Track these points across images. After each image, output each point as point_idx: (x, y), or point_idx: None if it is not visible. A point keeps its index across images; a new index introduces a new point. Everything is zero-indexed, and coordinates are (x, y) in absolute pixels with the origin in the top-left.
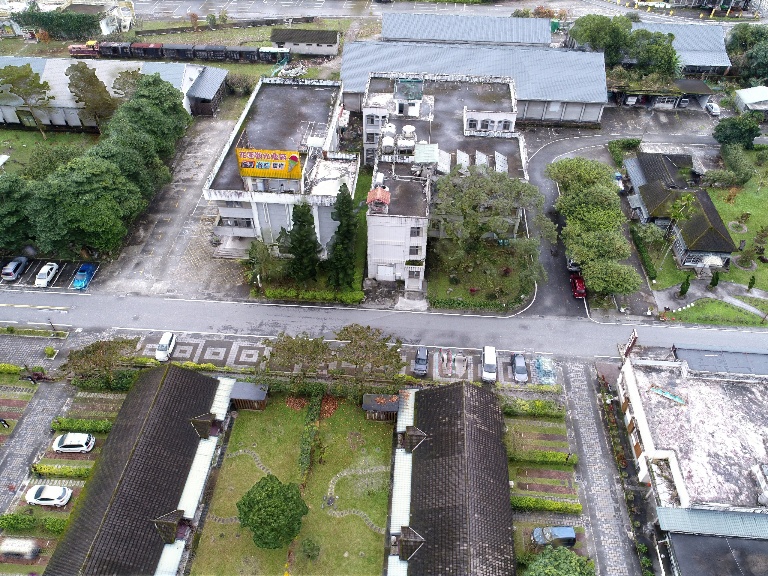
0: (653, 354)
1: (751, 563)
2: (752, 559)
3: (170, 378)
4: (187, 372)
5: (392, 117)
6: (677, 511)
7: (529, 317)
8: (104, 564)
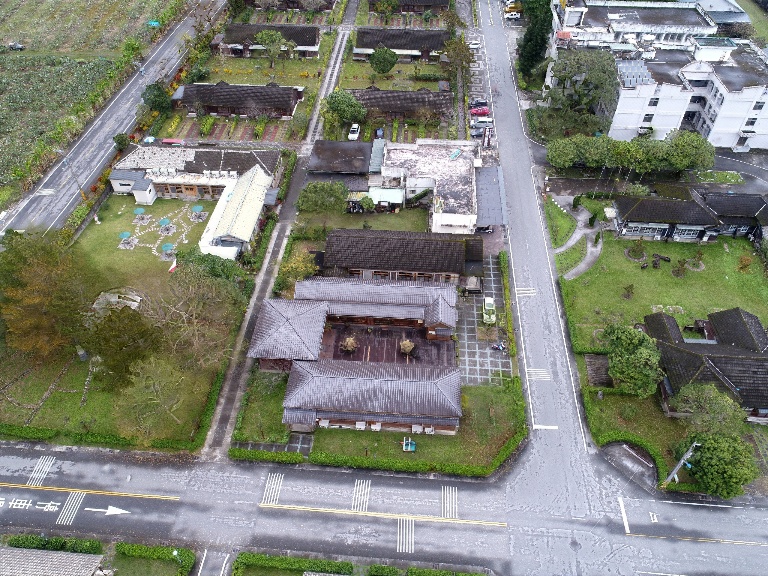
0: (492, 161)
1: (358, 161)
2: (360, 162)
3: (443, 33)
4: (449, 38)
5: (687, 51)
6: (383, 144)
7: (528, 143)
8: (363, 33)
